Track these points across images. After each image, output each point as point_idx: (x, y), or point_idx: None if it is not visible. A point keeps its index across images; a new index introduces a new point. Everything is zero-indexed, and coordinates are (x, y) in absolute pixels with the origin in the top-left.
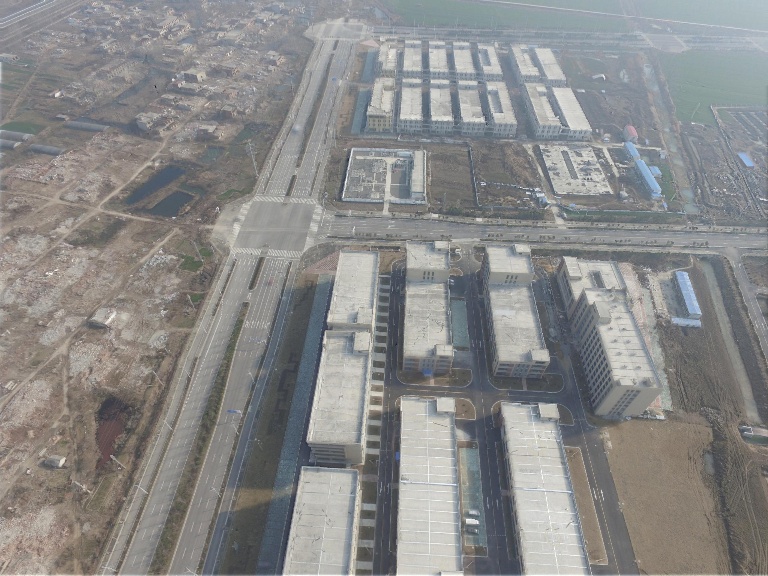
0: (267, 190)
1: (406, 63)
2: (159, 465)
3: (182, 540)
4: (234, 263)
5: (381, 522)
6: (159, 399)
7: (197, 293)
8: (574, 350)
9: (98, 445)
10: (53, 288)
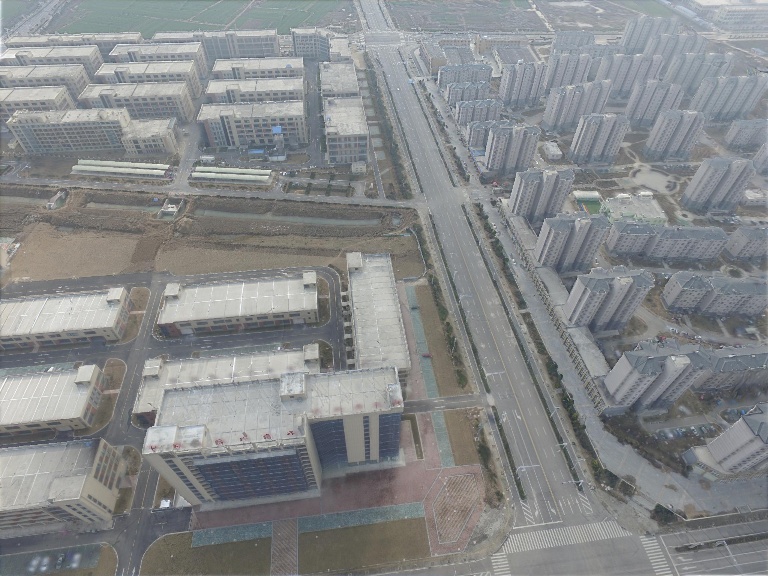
0: None
1: None
2: None
3: None
4: None
5: None
6: None
7: None
8: None
9: None
10: None
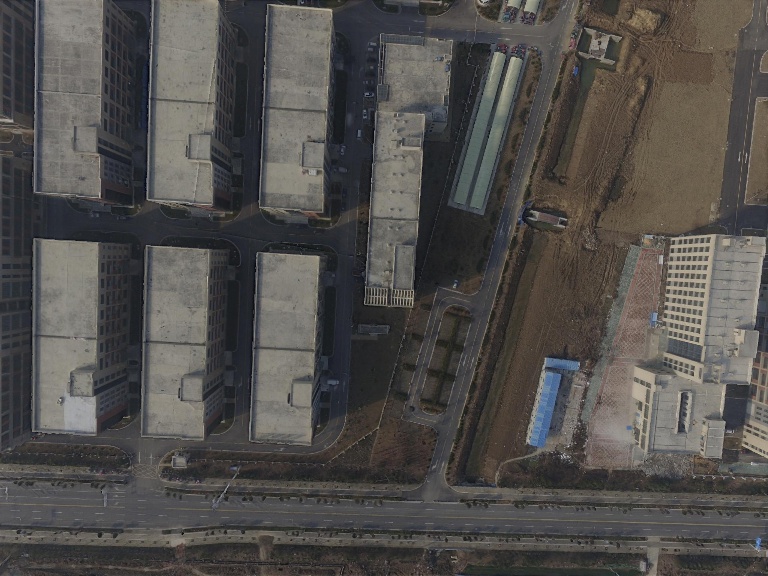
0: None
1: None
2: None
3: None
4: None
5: None
6: None
7: None
8: None
9: None
10: None
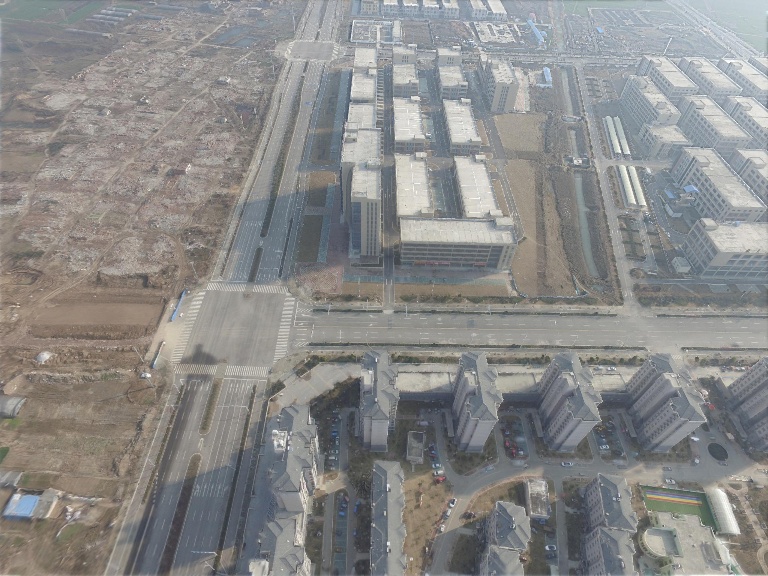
0: (303, 37)
1: None
2: (275, 122)
3: (294, 139)
4: (292, 63)
5: (386, 136)
6: (266, 106)
7: (273, 74)
8: (483, 94)
9: (240, 118)
10: (189, 70)
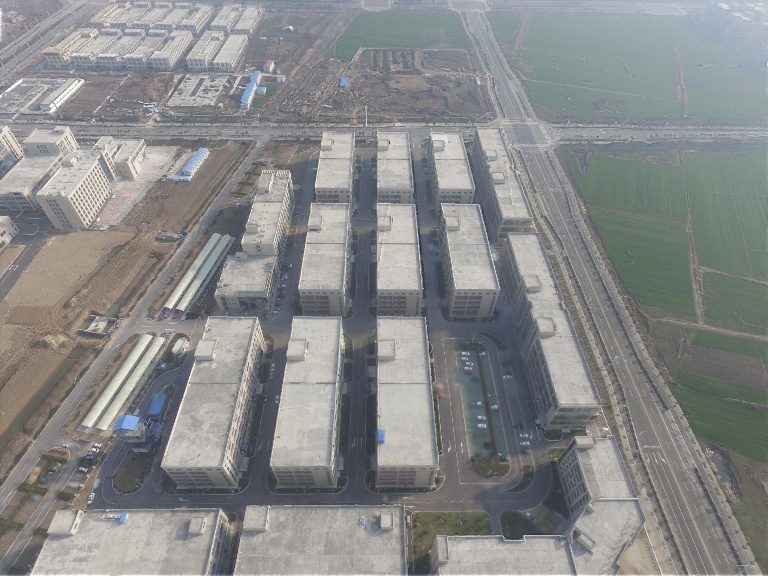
0: None
1: (122, 18)
2: None
3: None
4: None
5: None
6: None
7: None
8: None
9: None
10: None
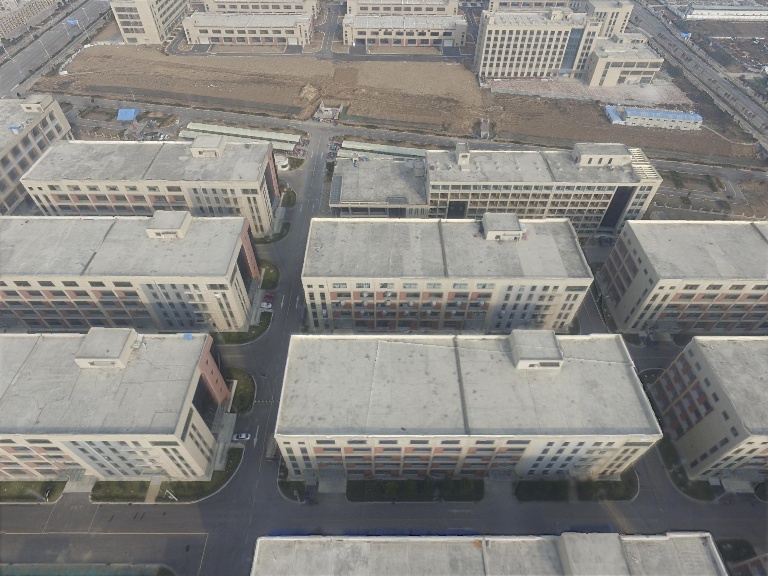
0: None
1: None
2: None
3: None
4: None
5: None
6: None
7: None
8: None
9: None
10: None
